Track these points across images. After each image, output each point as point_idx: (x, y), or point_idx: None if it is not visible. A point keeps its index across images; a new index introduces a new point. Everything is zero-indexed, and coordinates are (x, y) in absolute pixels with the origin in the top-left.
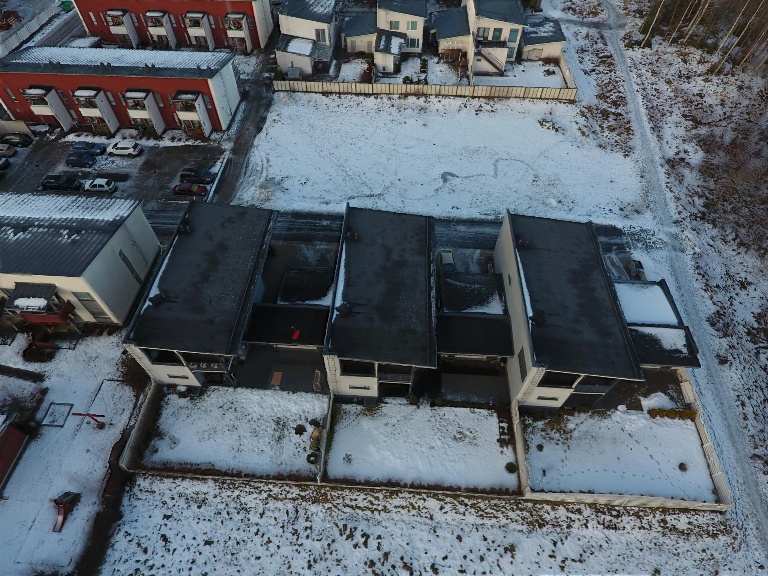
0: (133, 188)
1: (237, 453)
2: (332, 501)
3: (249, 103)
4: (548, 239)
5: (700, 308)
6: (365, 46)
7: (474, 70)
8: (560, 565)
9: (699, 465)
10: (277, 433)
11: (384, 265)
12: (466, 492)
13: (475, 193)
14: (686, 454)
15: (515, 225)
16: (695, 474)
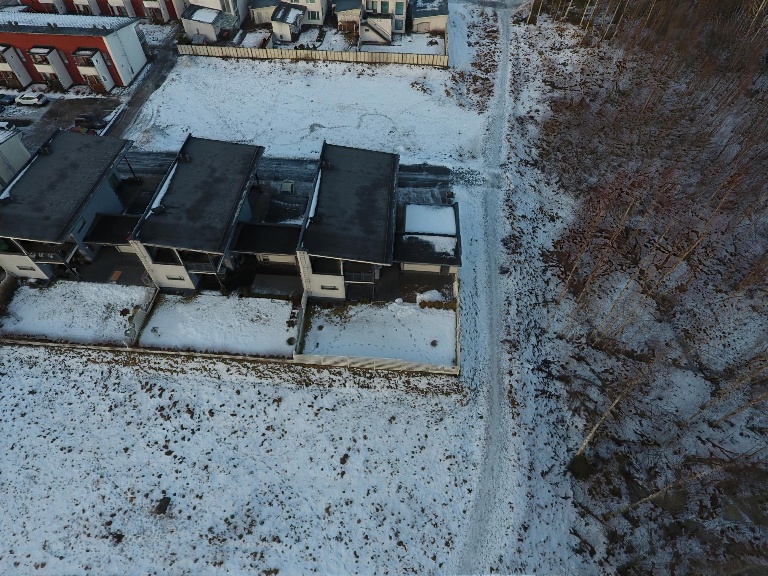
0: (32, 132)
1: (68, 328)
2: (139, 364)
3: (154, 65)
4: (352, 163)
5: (499, 231)
6: (270, 18)
7: (364, 40)
8: (315, 412)
9: (448, 342)
10: (105, 315)
11: (206, 180)
12: (247, 357)
13: (336, 141)
14: (440, 334)
15: (327, 152)
16: (443, 348)
